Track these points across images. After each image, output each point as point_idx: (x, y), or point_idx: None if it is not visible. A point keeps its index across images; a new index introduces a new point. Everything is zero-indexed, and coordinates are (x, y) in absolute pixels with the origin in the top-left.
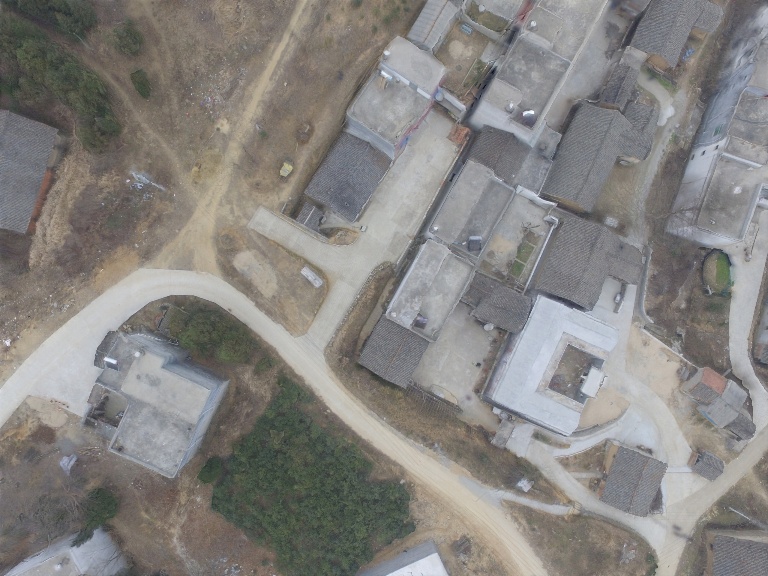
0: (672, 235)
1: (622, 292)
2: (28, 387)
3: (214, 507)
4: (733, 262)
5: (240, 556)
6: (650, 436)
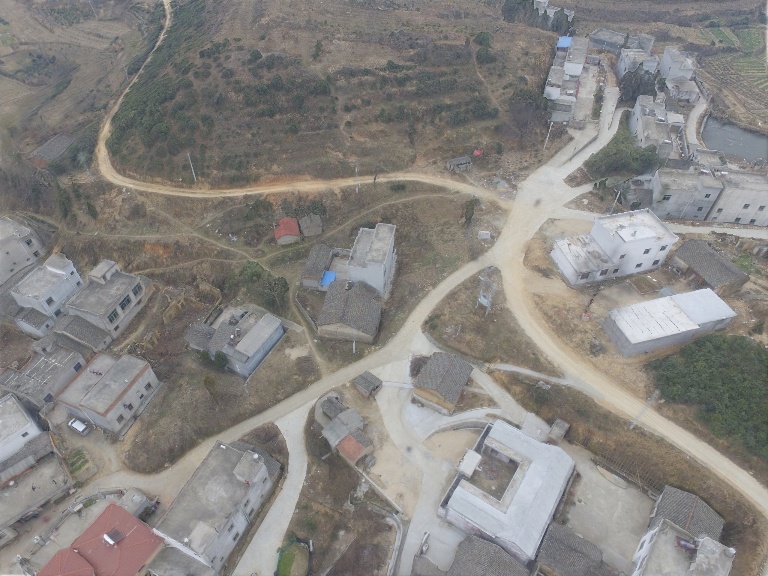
0: None
1: (421, 554)
2: None
3: None
4: (271, 575)
5: None
6: (410, 413)
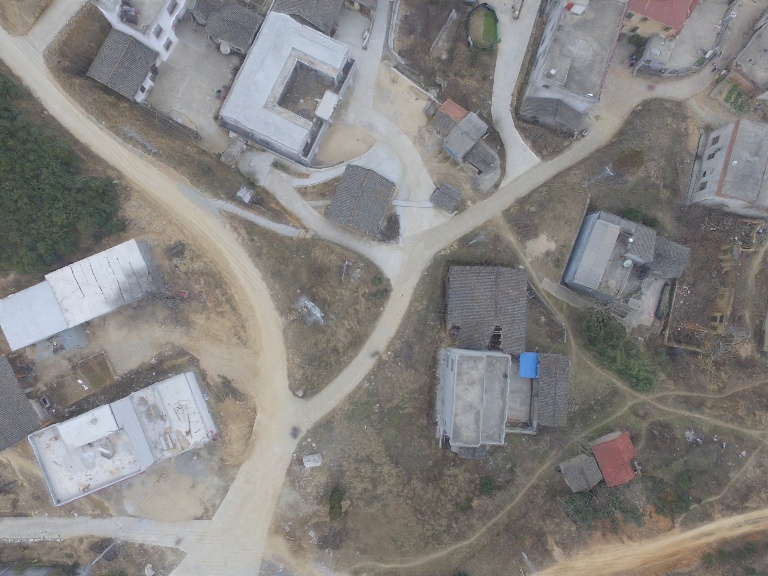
0: None
1: (369, 27)
2: None
3: None
4: (500, 19)
5: None
6: (393, 171)
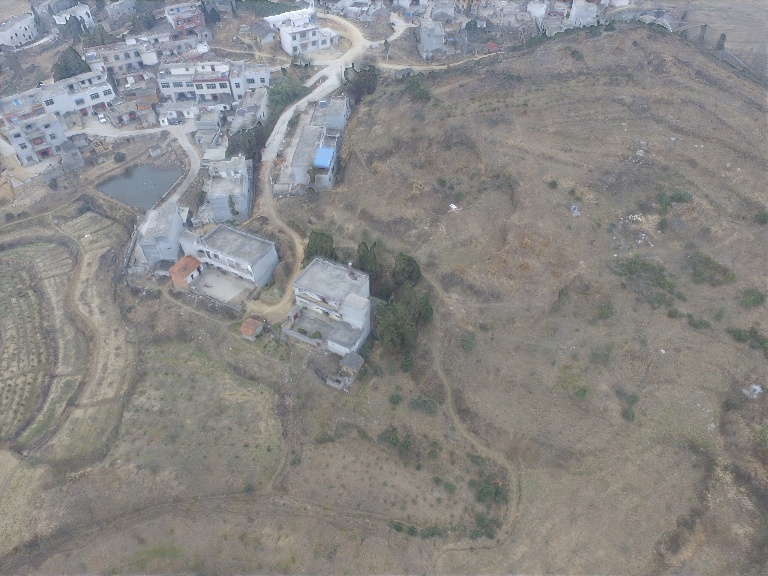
0: (393, 6)
1: None
2: None
3: (238, 5)
4: None
5: None
6: None
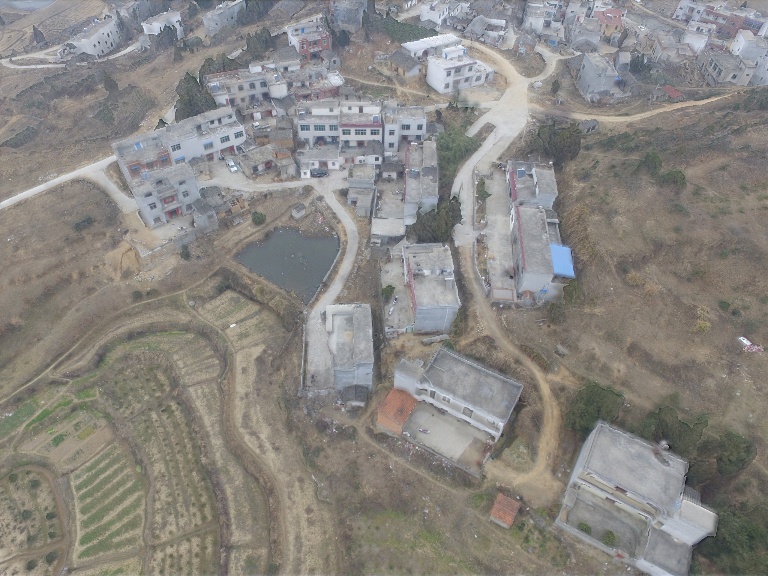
0: (523, 28)
1: None
2: None
3: (367, 26)
4: None
5: (376, 36)
6: None
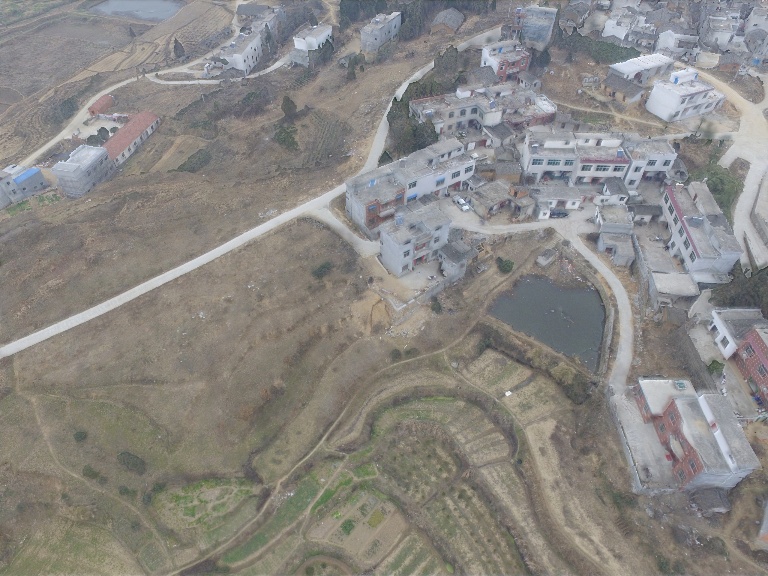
0: None
1: None
2: (470, 44)
3: (562, 45)
4: None
5: (576, 56)
6: None
